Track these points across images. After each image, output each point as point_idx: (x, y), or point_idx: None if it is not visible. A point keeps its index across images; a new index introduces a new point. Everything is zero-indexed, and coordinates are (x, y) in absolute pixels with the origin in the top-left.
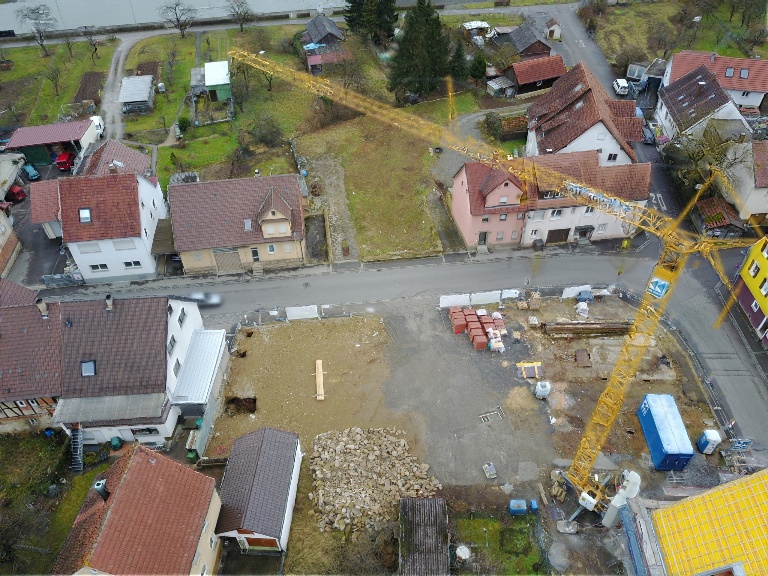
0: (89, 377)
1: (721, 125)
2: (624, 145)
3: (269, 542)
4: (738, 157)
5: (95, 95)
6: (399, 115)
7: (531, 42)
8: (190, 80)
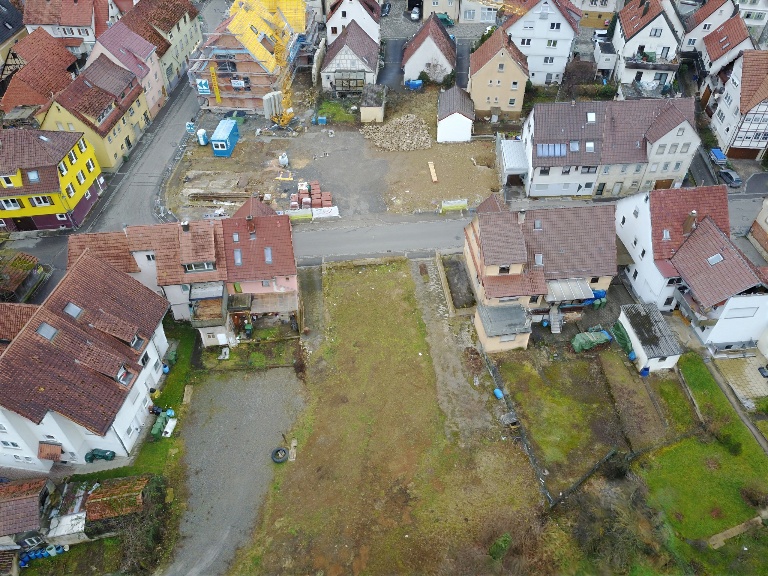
0: None
1: None
2: None
3: None
4: None
5: None
6: None
7: None
8: None
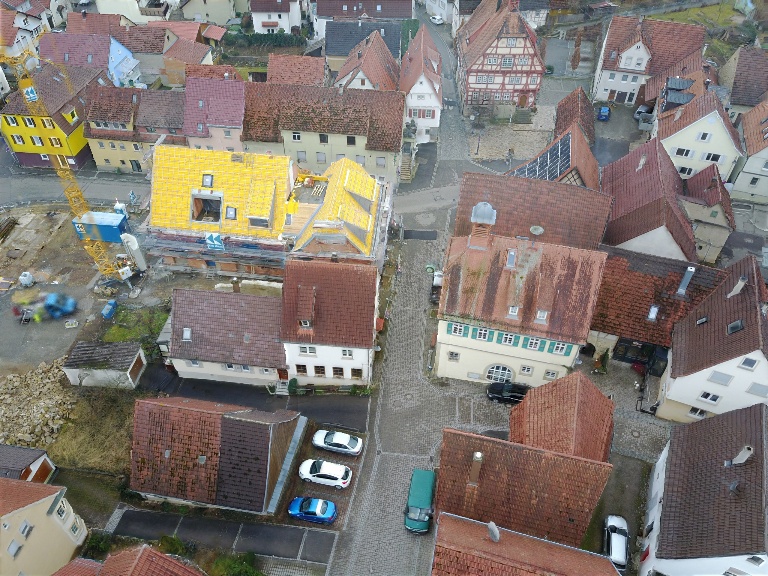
0: None
1: None
2: None
3: (43, 473)
4: None
5: None
6: None
7: None
8: None
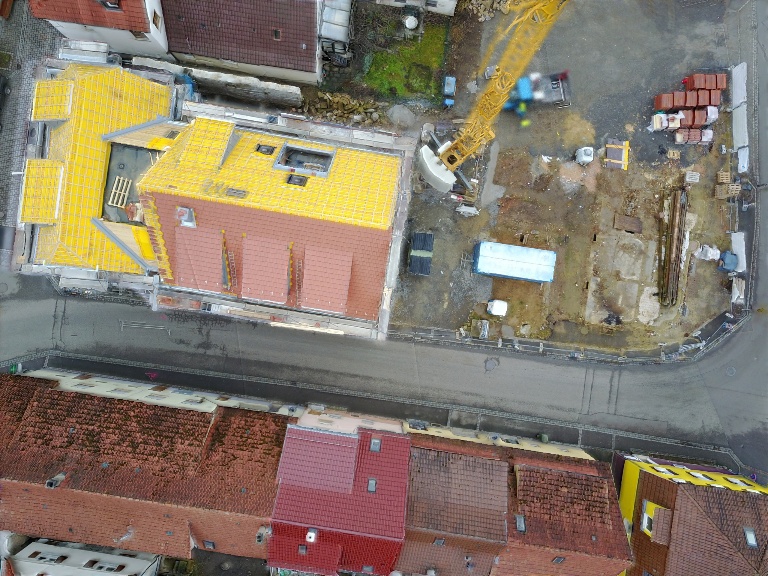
0: None
1: None
2: None
3: None
4: None
5: None
6: None
7: None
8: None
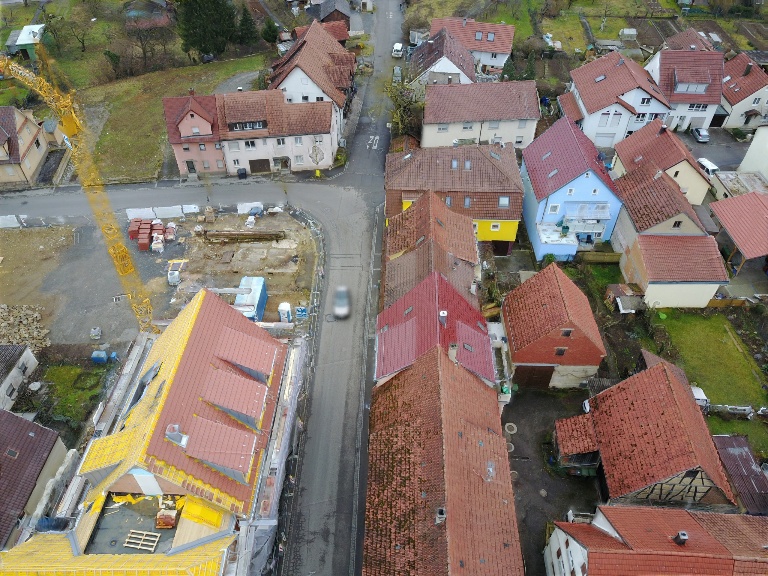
0: None
1: (436, 77)
2: (327, 89)
3: None
4: None
5: None
6: (186, 72)
7: (330, 11)
8: None
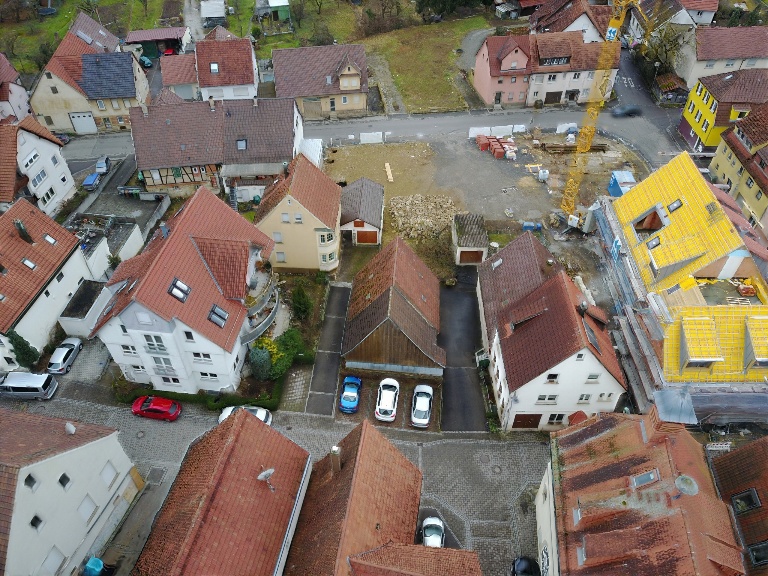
0: (242, 151)
1: None
2: (602, 34)
3: (371, 238)
4: (686, 41)
5: (178, 15)
6: (427, 29)
7: None
8: (255, 4)
